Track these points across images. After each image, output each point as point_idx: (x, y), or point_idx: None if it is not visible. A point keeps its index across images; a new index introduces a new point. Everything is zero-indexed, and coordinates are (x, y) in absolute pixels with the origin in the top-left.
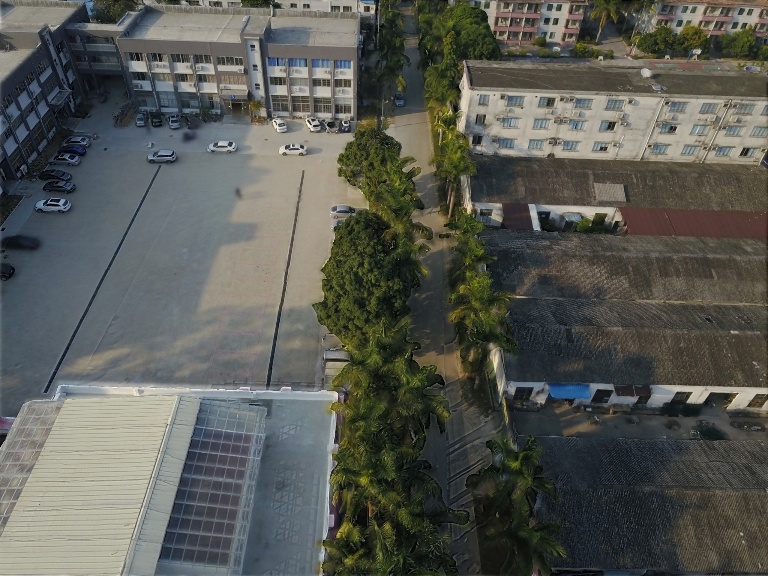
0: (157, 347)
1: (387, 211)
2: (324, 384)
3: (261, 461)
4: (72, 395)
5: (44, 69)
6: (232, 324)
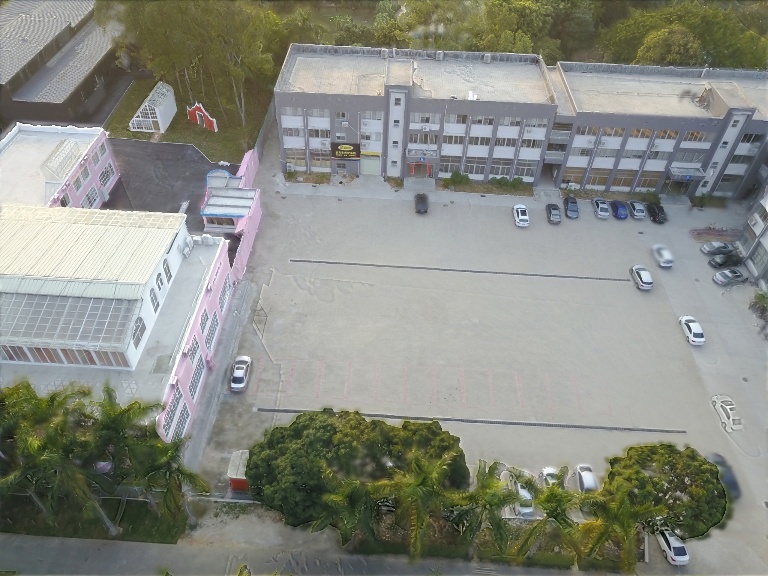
0: (332, 318)
1: (437, 469)
2: (241, 450)
3: (106, 369)
4: (217, 247)
5: (699, 140)
6: (361, 372)
